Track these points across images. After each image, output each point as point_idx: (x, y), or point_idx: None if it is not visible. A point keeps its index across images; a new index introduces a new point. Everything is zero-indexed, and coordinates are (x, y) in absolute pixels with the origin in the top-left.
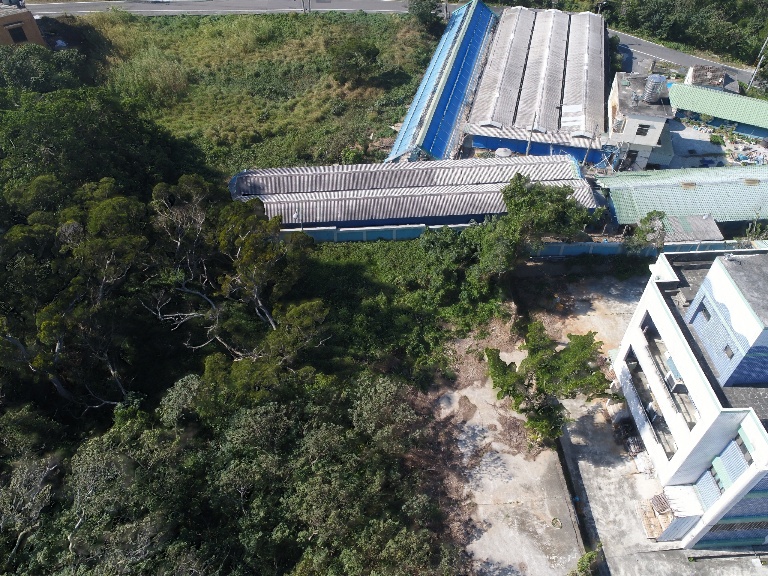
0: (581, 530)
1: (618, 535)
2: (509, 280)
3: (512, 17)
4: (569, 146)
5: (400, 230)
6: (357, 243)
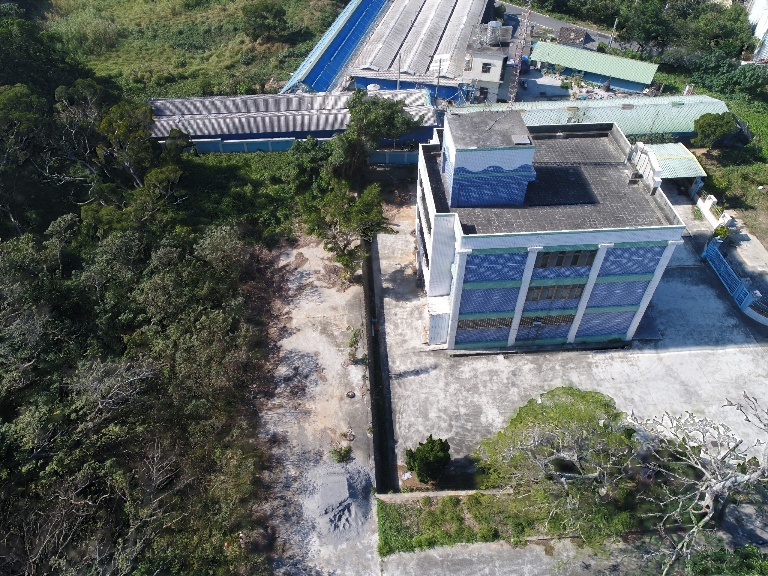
0: (375, 340)
1: (401, 342)
2: (356, 178)
3: None
4: (432, 85)
5: (274, 142)
6: (239, 153)
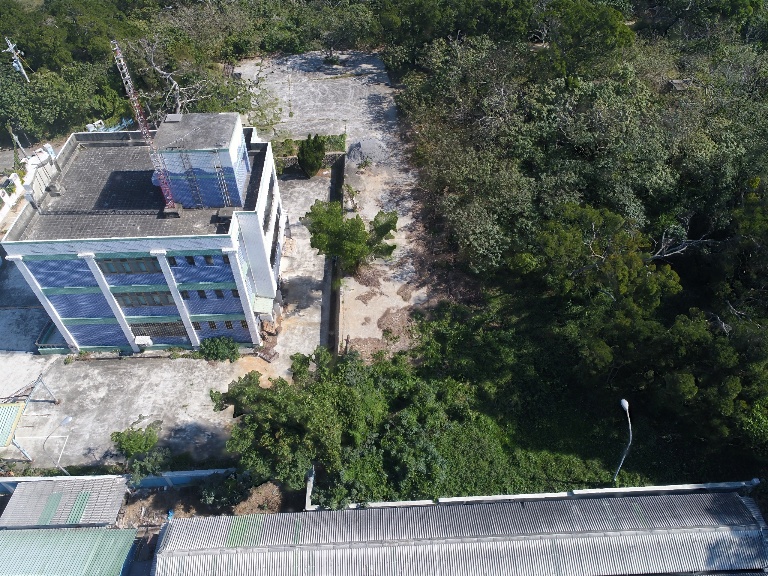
0: None
1: None
2: None
3: None
4: None
5: None
6: (537, 491)
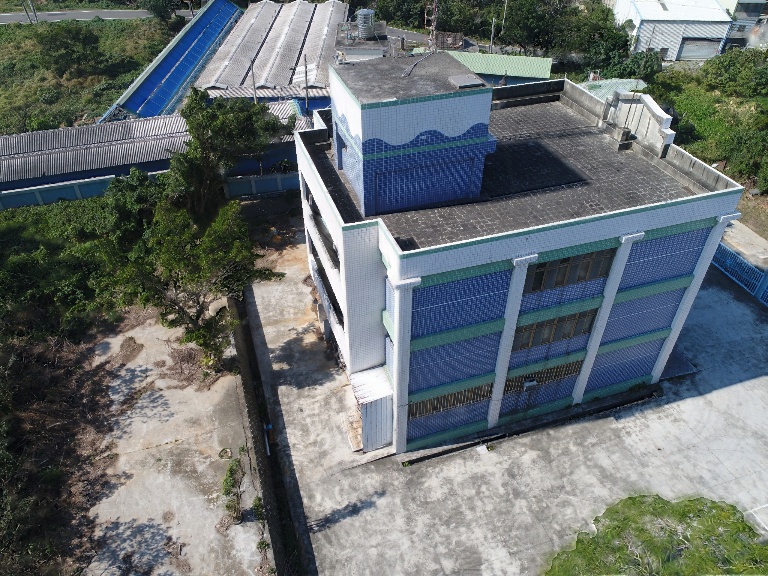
0: (273, 463)
1: (318, 457)
2: None
3: (256, 8)
4: (300, 98)
5: (83, 185)
6: (28, 207)
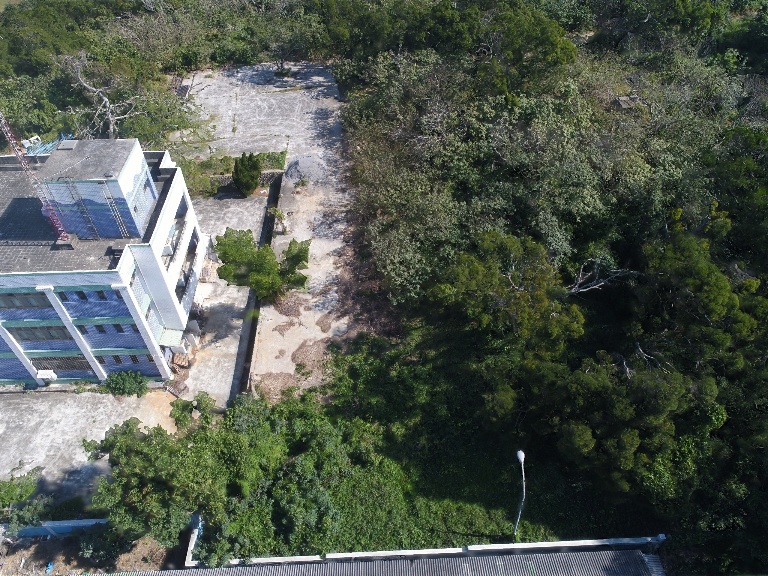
0: None
1: None
2: None
3: None
4: None
5: None
6: (434, 545)
